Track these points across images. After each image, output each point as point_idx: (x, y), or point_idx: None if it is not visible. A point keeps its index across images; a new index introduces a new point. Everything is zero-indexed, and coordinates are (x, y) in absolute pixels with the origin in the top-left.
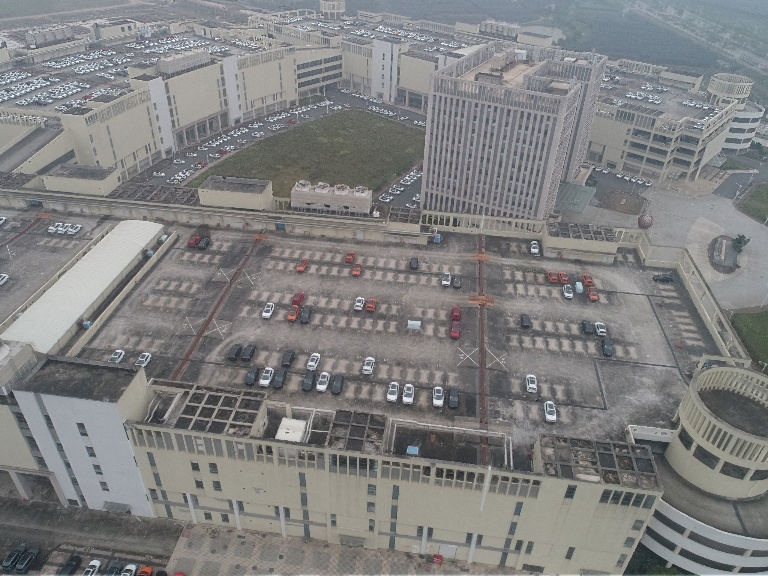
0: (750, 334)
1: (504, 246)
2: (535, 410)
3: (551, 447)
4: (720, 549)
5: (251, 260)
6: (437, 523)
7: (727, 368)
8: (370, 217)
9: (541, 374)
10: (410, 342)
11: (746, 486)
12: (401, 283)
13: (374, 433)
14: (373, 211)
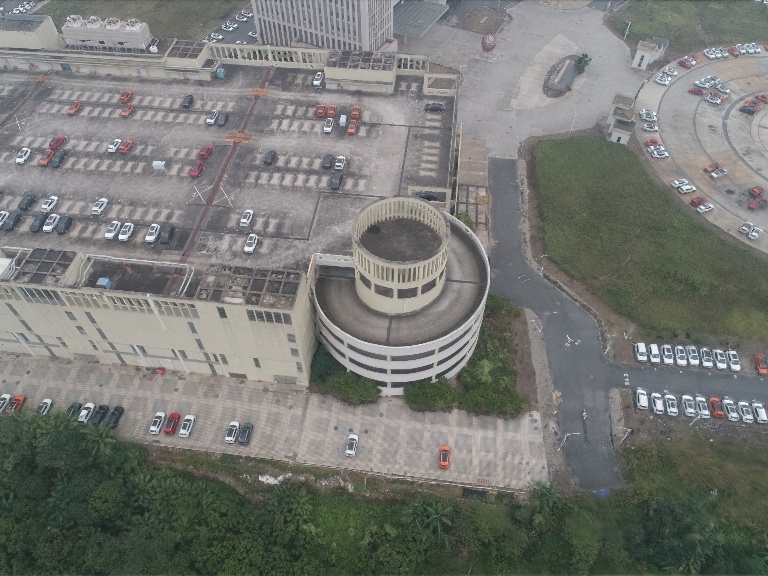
0: (543, 161)
1: (290, 79)
2: (240, 242)
3: (214, 275)
4: (369, 356)
5: (27, 104)
6: (141, 342)
7: (402, 198)
8: (147, 53)
9: (262, 209)
10: (151, 182)
11: (397, 303)
12: (168, 123)
13: (60, 268)
14: (152, 46)
